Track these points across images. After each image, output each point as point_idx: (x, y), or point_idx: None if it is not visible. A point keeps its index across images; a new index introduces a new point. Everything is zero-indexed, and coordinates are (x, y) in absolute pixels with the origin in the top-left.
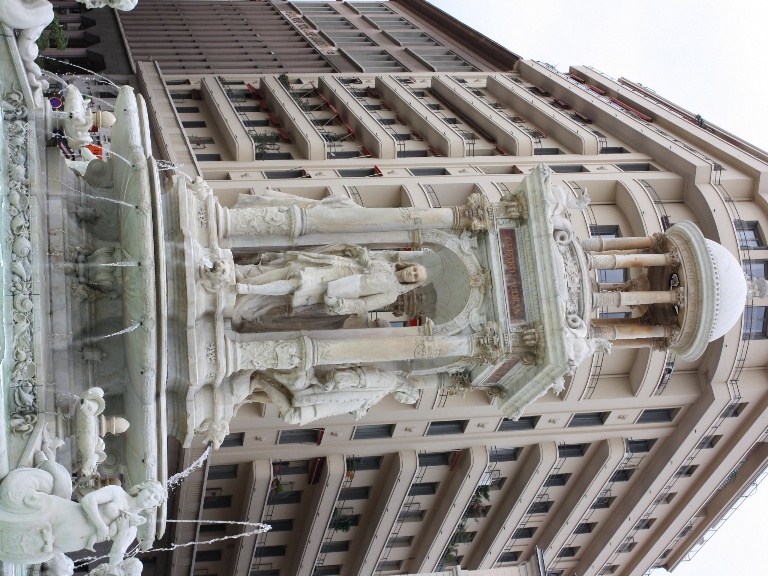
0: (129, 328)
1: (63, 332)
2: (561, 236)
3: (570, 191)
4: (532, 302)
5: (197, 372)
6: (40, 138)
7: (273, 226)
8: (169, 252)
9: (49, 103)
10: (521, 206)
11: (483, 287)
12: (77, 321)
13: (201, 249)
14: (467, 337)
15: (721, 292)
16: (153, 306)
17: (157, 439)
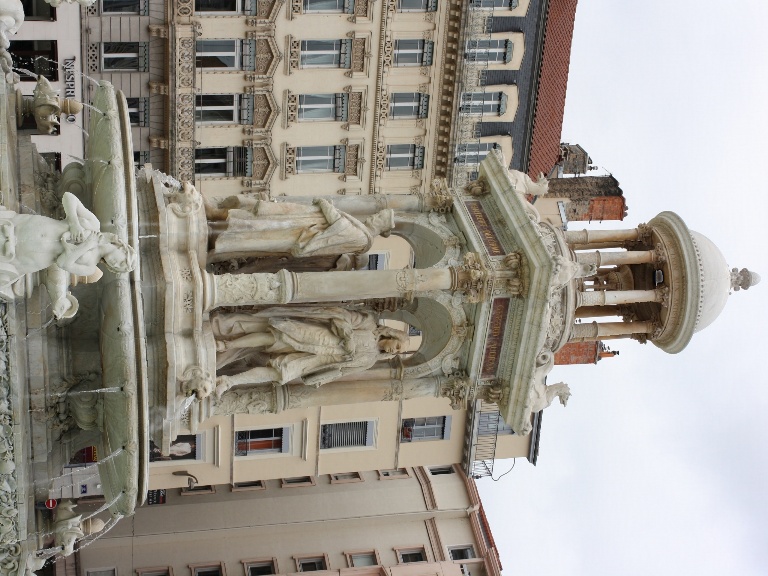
0: None
1: None
2: None
3: (578, 269)
4: (506, 364)
5: None
6: (20, 303)
7: None
8: (151, 368)
9: (30, 275)
10: (523, 287)
11: (463, 337)
12: None
13: (184, 360)
14: (435, 387)
15: None
16: None
17: None
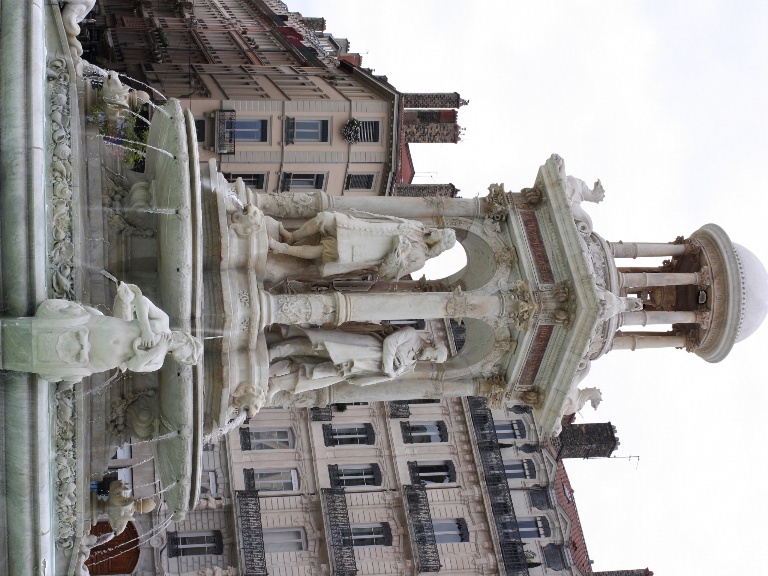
0: None
1: None
2: None
3: None
4: None
5: None
6: None
7: None
8: None
9: None
10: None
11: None
12: None
13: None
14: None
15: None
16: None
17: None
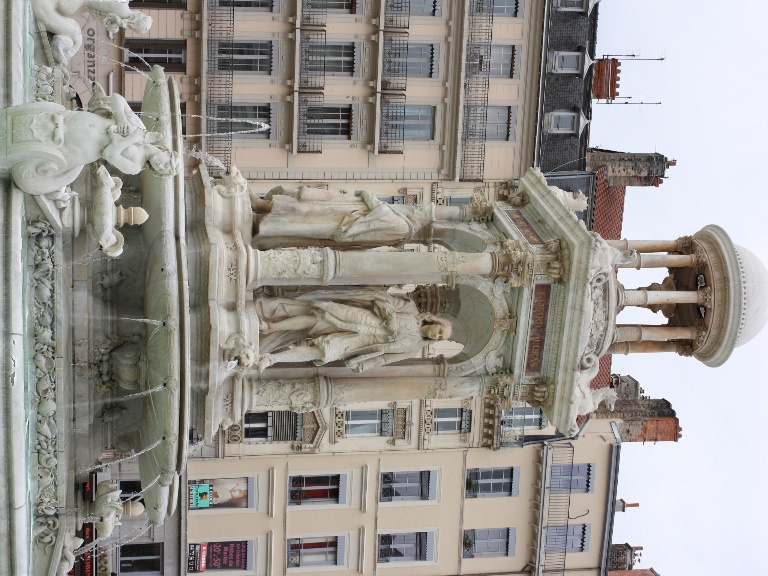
0: (150, 485)
1: (85, 428)
2: (598, 278)
3: (618, 252)
4: (550, 359)
5: (212, 428)
6: (67, 242)
7: (304, 277)
8: (194, 334)
9: (77, 209)
10: (563, 269)
11: (506, 331)
12: (99, 406)
13: (227, 328)
14: (479, 385)
15: (742, 334)
16: (174, 462)
17: (169, 489)
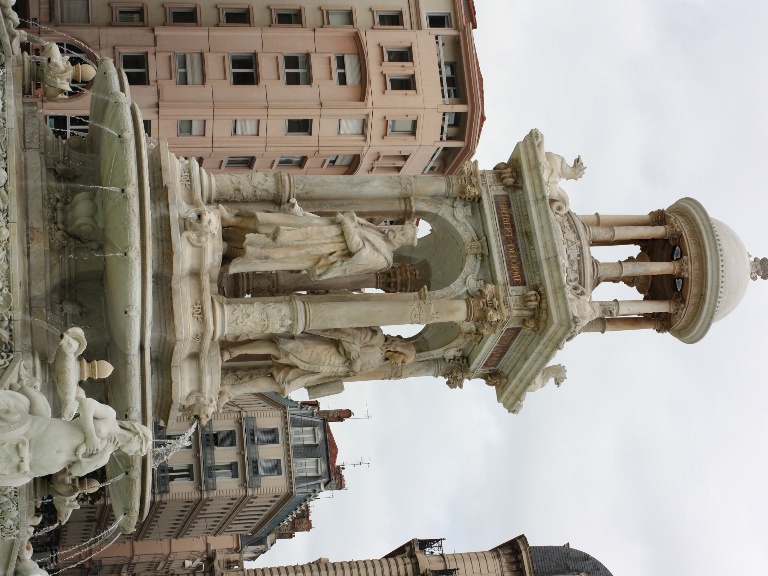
0: None
1: None
2: None
3: None
4: (508, 364)
5: None
6: None
7: None
8: None
9: None
10: (537, 328)
11: (470, 340)
12: None
13: (189, 389)
14: (434, 372)
15: None
16: None
17: None
